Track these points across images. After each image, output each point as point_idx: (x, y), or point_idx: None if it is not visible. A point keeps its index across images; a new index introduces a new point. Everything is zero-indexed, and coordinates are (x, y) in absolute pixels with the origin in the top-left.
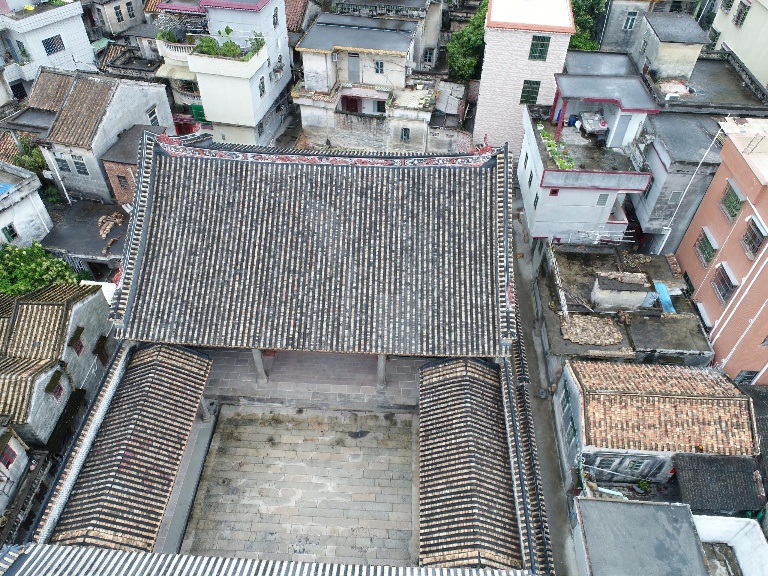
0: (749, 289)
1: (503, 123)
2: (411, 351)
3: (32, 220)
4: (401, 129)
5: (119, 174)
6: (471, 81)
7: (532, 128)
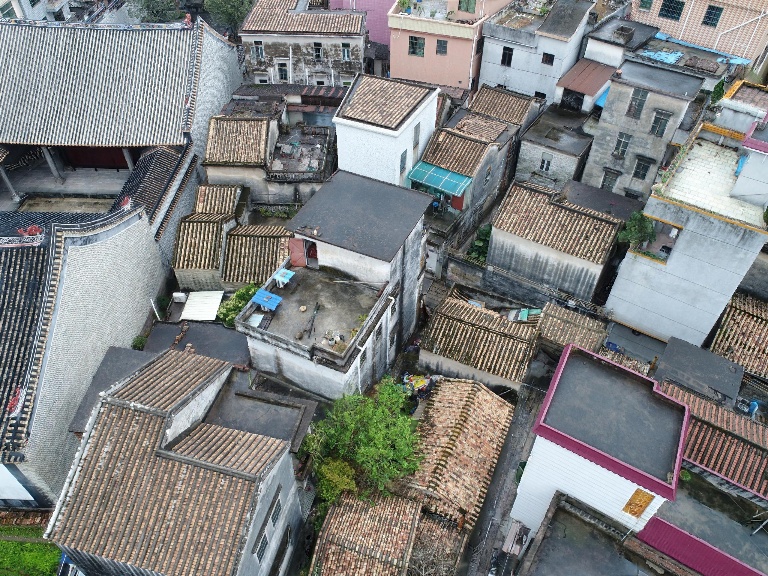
0: None
1: None
2: None
3: None
4: None
5: None
6: None
7: None
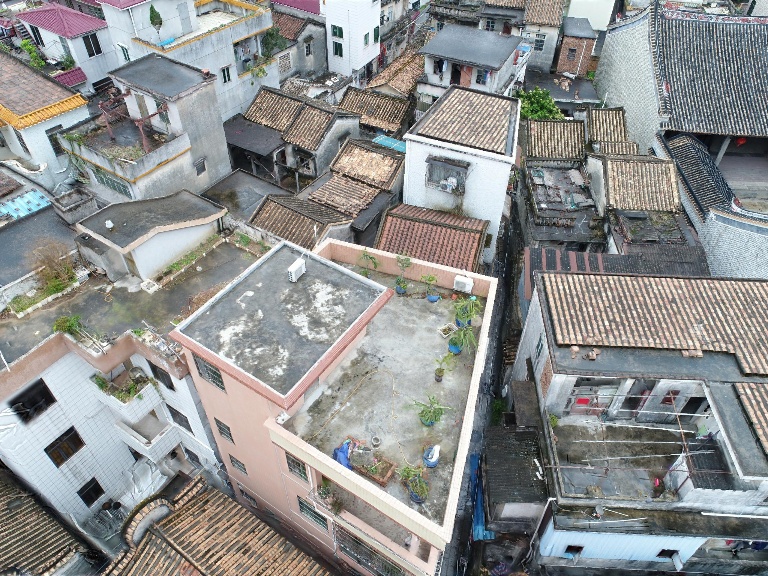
0: None
1: None
2: None
3: (521, 77)
4: None
5: (572, 47)
6: (740, 4)
7: None
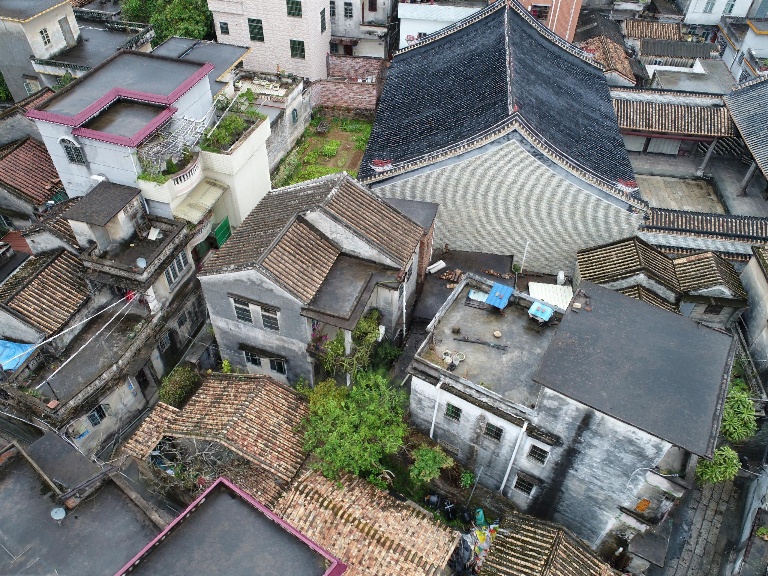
0: (561, 0)
1: (319, 58)
2: (612, 107)
3: None
4: (291, 114)
5: None
6: None
7: (436, 5)
